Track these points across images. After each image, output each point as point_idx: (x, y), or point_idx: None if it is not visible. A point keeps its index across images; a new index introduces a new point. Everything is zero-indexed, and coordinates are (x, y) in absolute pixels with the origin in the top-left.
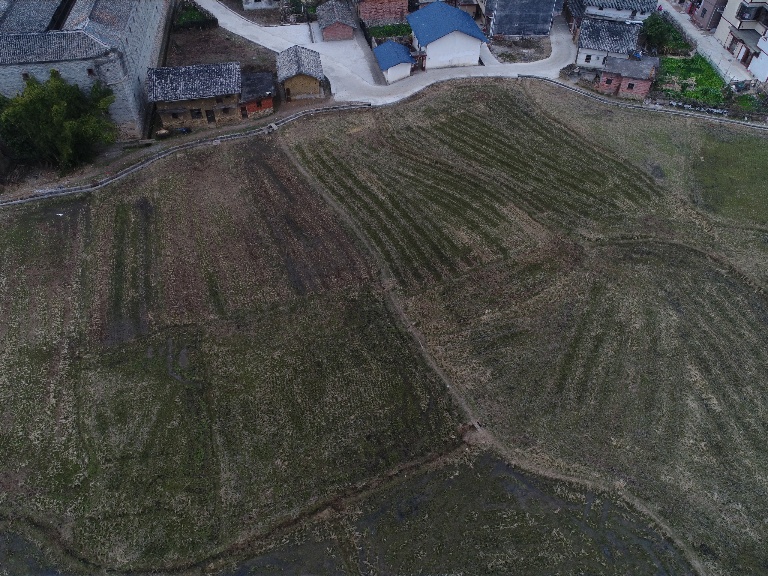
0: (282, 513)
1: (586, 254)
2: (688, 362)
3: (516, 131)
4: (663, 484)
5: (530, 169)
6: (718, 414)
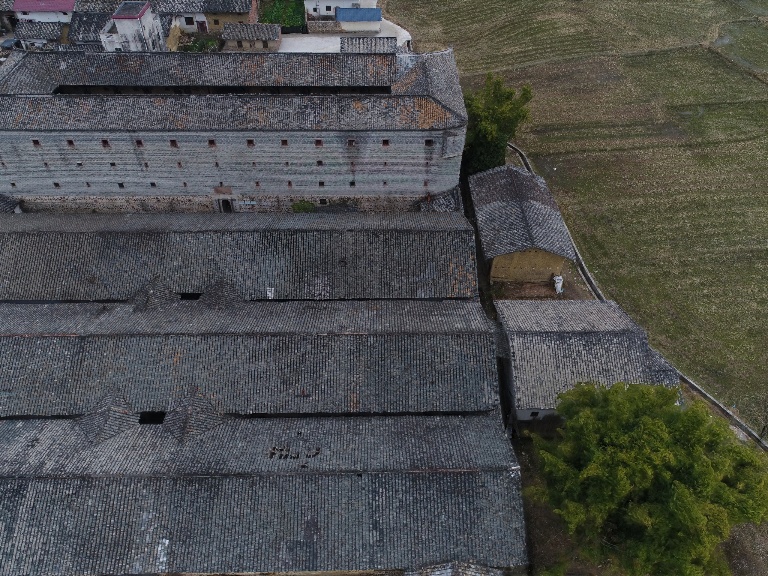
0: (764, 87)
1: (577, 8)
2: (645, 3)
3: (454, 5)
4: (710, 18)
5: (499, 7)
6: (672, 4)
